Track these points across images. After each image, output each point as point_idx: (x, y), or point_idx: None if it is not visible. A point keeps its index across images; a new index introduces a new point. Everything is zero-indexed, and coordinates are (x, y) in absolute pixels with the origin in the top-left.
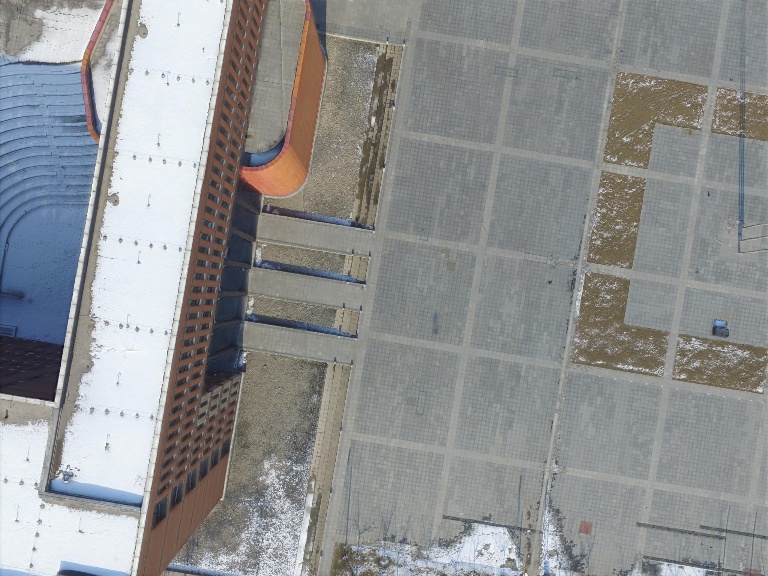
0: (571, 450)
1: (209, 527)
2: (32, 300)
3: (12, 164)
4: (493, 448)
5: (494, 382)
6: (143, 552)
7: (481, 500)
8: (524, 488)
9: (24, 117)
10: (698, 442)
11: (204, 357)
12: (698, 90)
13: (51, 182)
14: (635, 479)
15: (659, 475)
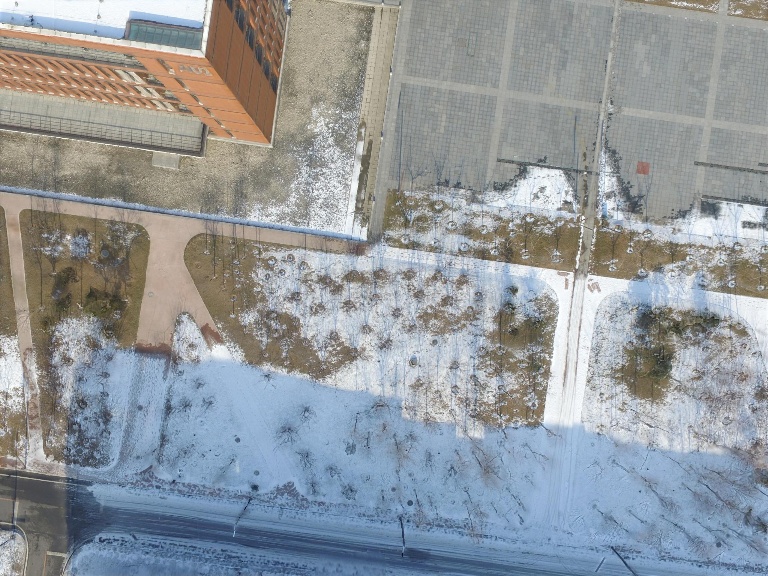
0: (626, 89)
1: (257, 178)
2: None
3: None
4: (547, 89)
5: (546, 21)
6: (215, 3)
7: (536, 142)
8: (579, 129)
9: None
10: (755, 78)
11: None
12: None
13: None
14: (692, 117)
15: (716, 113)
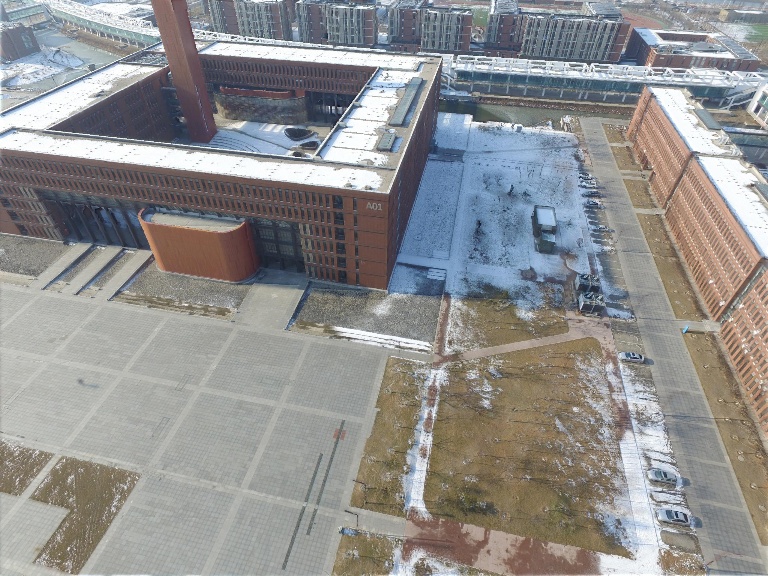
0: None
1: None
2: None
3: None
4: None
5: None
6: None
7: None
8: None
9: None
10: None
11: (48, 186)
12: (80, 562)
13: None
14: None
15: None
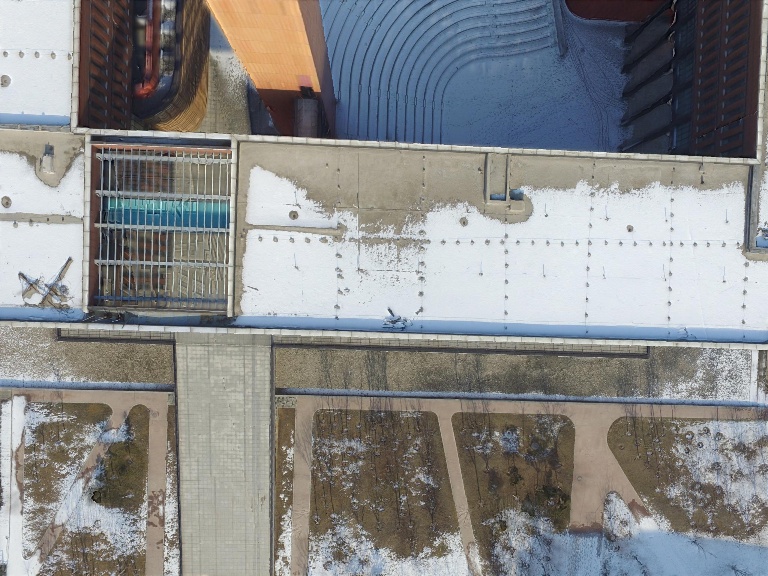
0: None
1: (666, 358)
2: None
3: (446, 18)
4: None
5: None
6: None
7: None
8: None
9: None
10: None
11: None
12: None
13: (483, 34)
14: None
15: None
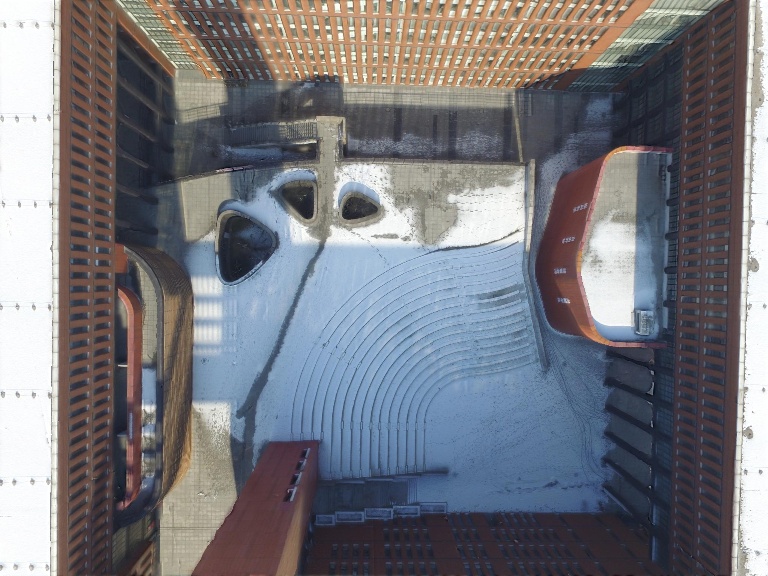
0: None
1: None
2: (456, 473)
3: (427, 346)
4: None
5: None
6: None
7: None
8: None
9: (441, 300)
10: None
11: None
12: None
13: (464, 357)
14: None
15: None
